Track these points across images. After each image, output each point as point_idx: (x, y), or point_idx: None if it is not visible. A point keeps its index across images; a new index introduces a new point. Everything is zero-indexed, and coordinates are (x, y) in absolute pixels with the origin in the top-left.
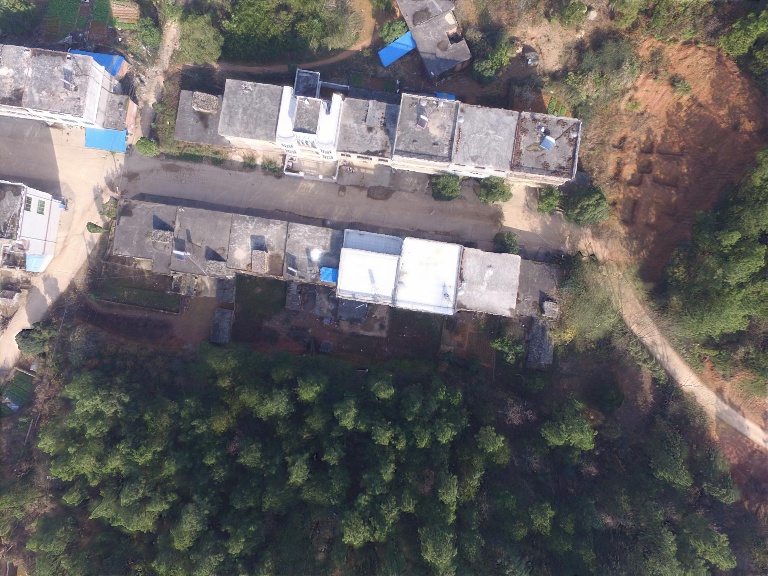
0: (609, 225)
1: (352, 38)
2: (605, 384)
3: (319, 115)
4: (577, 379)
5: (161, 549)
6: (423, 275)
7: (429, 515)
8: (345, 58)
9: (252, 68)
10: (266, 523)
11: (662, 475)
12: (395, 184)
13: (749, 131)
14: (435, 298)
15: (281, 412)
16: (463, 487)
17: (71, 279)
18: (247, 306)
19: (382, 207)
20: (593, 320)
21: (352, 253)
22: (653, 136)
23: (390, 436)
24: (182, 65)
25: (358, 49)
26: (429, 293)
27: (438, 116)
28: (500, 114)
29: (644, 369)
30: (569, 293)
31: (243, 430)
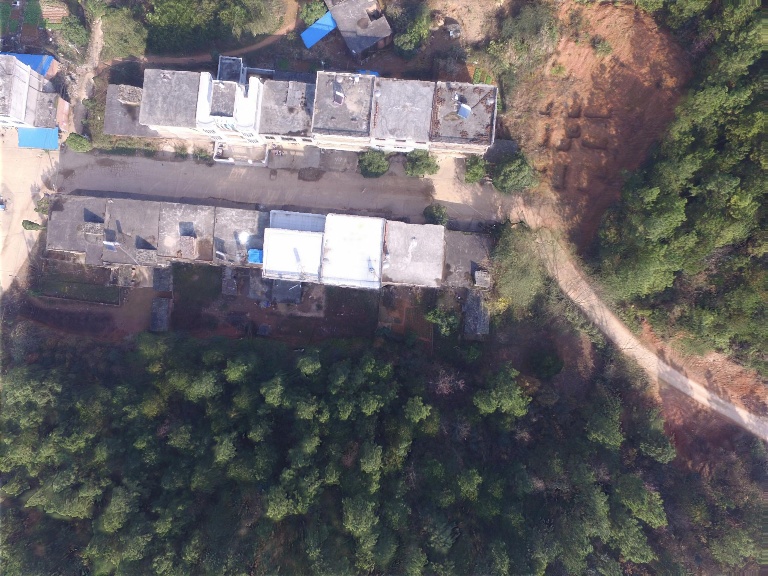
0: (540, 192)
1: (276, 23)
2: (544, 351)
3: (235, 98)
4: (516, 348)
5: (95, 533)
6: (348, 251)
7: (351, 485)
8: (270, 43)
9: (179, 59)
10: (197, 503)
11: (595, 437)
12: (325, 164)
13: (672, 87)
14: (361, 273)
15: (210, 393)
16: (388, 457)
17: (13, 277)
18: (185, 294)
19: (314, 188)
20: (529, 288)
21: (276, 233)
22: (580, 100)
23: (314, 410)
24: (111, 61)
25: (283, 33)
26: (355, 268)
27: (355, 92)
28: (416, 86)
29: (583, 334)
30: (500, 262)
31: (175, 413)
